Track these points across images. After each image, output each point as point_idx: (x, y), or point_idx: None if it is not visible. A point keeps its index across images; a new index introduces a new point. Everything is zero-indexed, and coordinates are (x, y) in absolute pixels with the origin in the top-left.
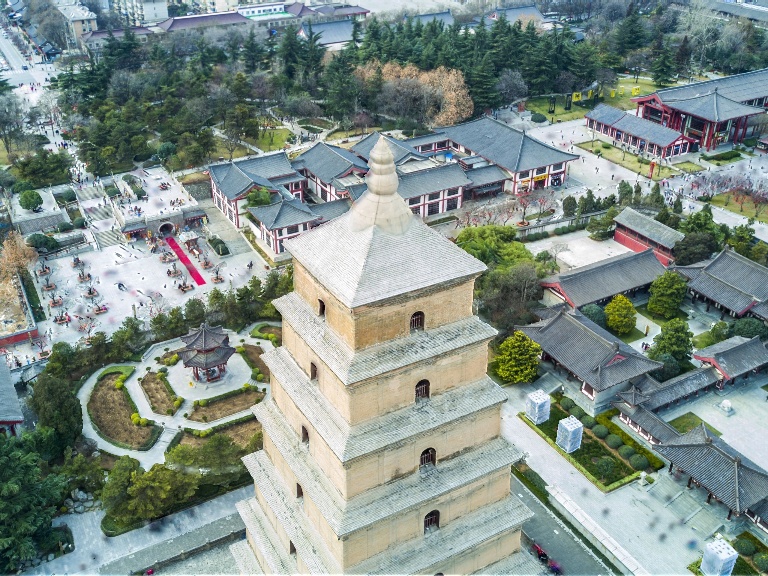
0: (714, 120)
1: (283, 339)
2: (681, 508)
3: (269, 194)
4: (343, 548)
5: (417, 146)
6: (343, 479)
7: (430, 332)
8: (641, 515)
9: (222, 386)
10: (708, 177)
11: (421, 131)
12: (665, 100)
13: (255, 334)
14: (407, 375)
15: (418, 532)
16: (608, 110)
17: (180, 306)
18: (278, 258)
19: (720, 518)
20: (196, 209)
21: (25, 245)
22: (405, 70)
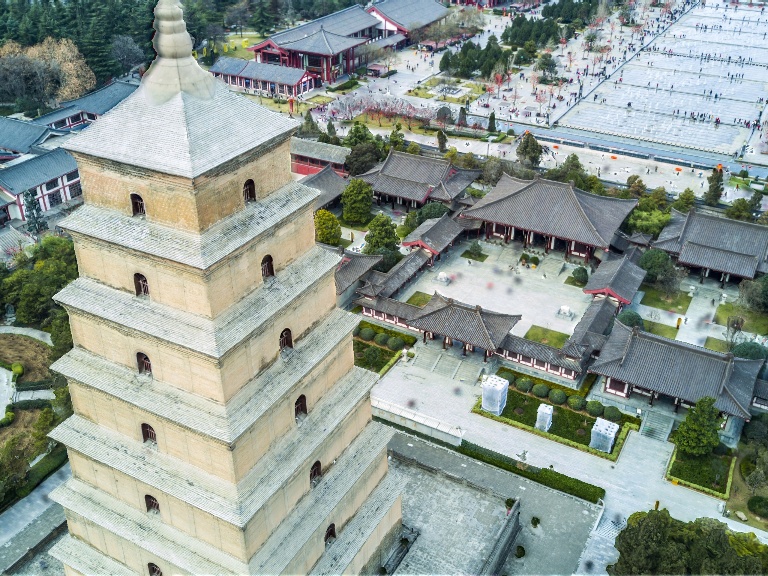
0: (329, 54)
1: (79, 268)
2: (445, 368)
3: None
4: (232, 459)
5: (49, 124)
6: (217, 382)
7: (262, 202)
8: (417, 385)
9: None
10: (345, 102)
11: (45, 110)
12: (280, 43)
13: None
14: (253, 251)
15: (291, 423)
16: (230, 61)
17: None
18: None
19: (479, 364)
20: None
21: None
22: (5, 48)
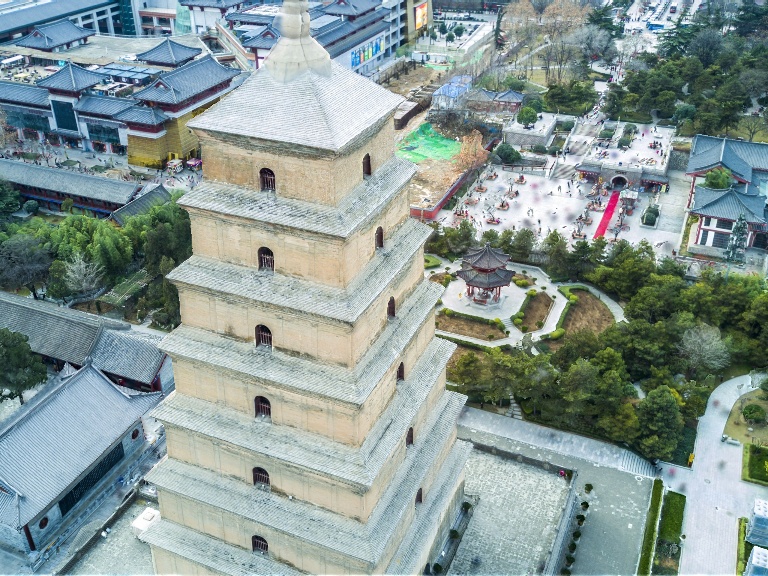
0: None
1: None
2: None
3: (737, 182)
4: None
5: None
6: None
7: (280, 199)
8: None
9: (481, 310)
10: None
11: None
12: None
13: (563, 289)
14: (247, 231)
15: (249, 409)
16: None
17: (513, 230)
18: (694, 249)
19: None
20: (659, 173)
21: (481, 146)
22: None
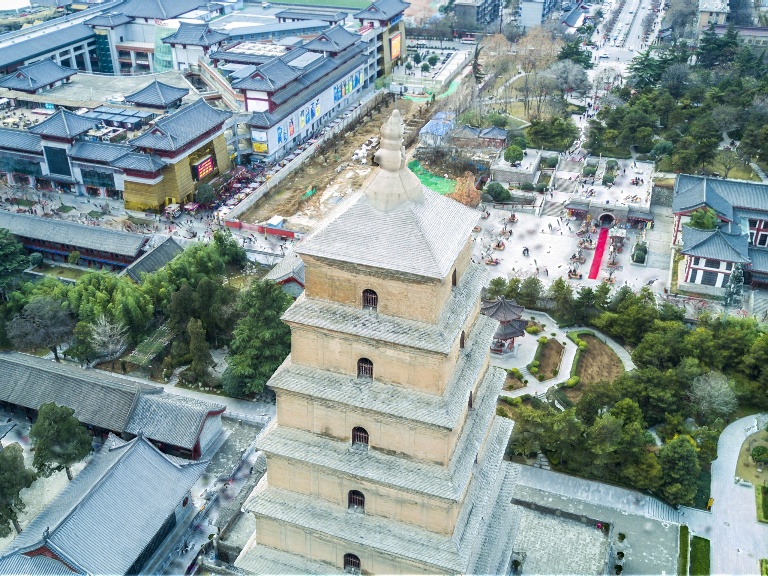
0: None
1: None
2: None
3: (720, 221)
4: None
5: None
6: None
7: (382, 316)
8: None
9: (498, 360)
10: None
11: None
12: None
13: (571, 335)
14: (348, 344)
15: (342, 501)
16: None
17: (520, 278)
18: (684, 286)
19: None
20: (644, 211)
21: (474, 187)
22: None
